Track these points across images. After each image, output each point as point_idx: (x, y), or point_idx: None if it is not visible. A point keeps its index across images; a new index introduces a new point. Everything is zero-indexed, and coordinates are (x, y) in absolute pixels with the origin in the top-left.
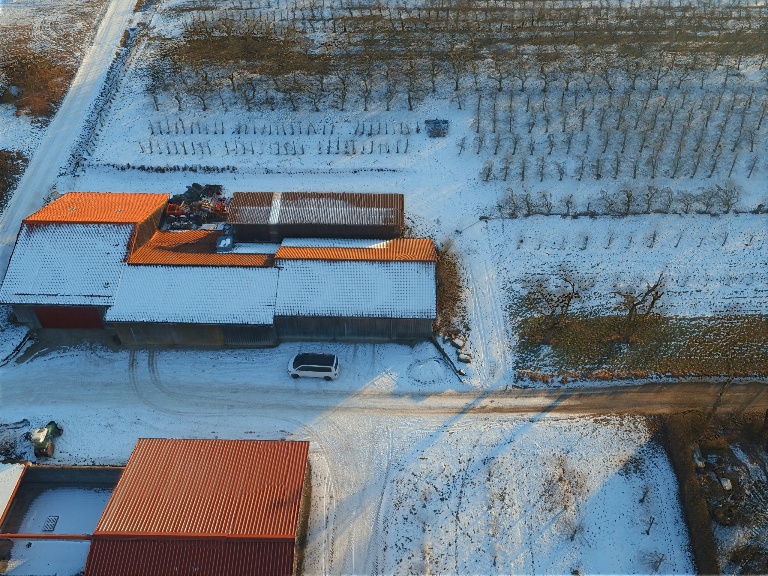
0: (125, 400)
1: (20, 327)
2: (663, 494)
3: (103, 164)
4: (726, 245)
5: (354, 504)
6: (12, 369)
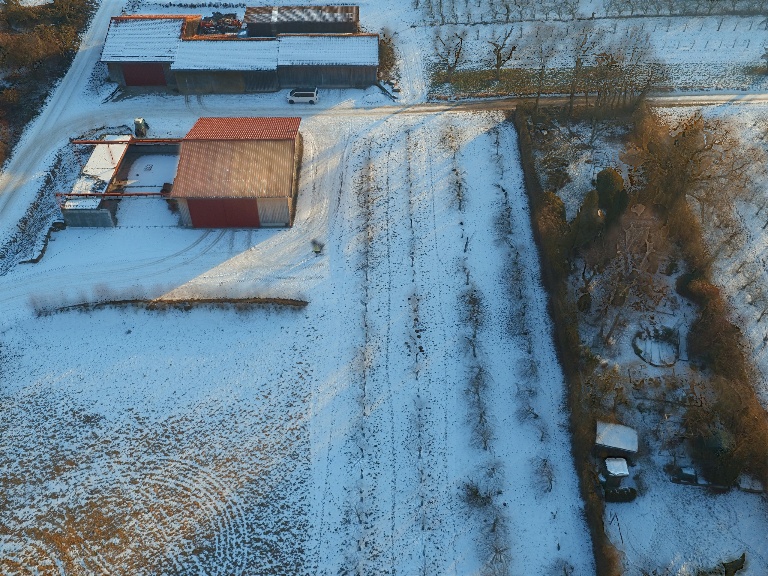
0: (185, 115)
1: (113, 83)
2: (509, 140)
3: (153, 4)
4: (569, 35)
5: (329, 152)
6: (111, 104)
